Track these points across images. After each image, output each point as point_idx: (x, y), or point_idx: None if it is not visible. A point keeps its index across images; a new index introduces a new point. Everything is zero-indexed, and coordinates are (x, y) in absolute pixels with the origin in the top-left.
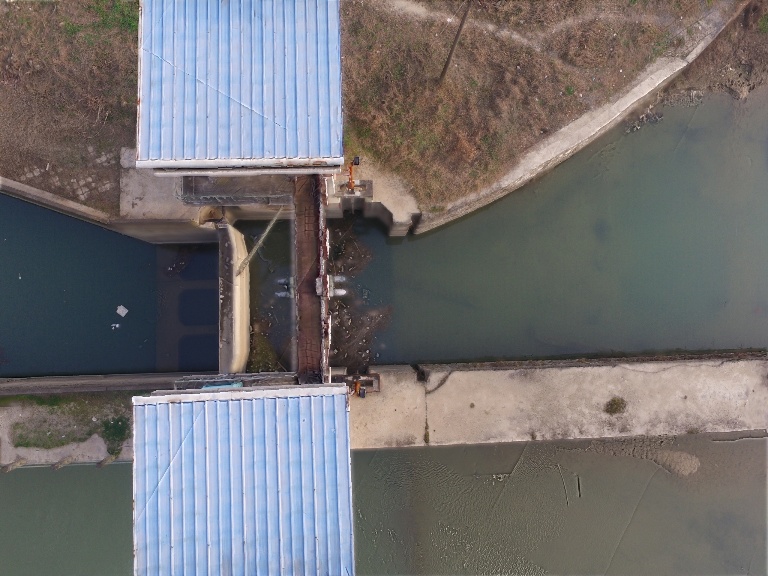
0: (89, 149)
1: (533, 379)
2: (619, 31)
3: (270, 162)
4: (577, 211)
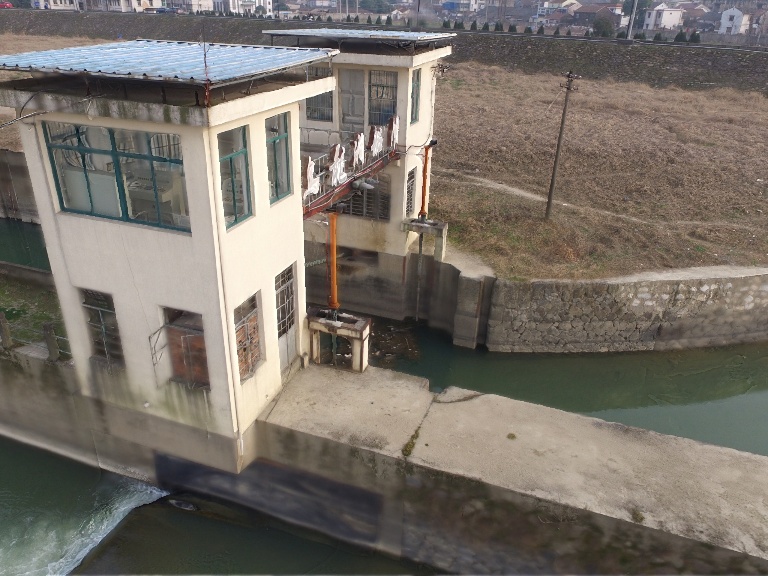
0: None
1: (641, 439)
2: (759, 235)
3: (360, 34)
4: (745, 399)
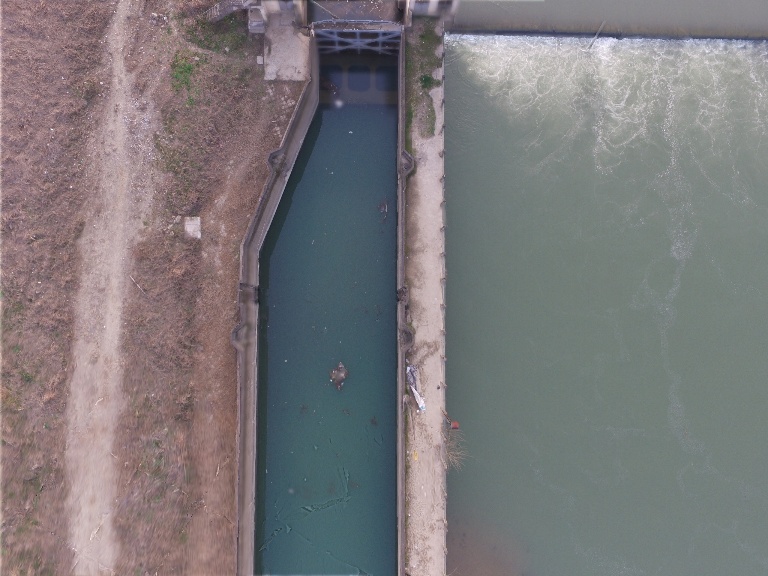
0: (264, 99)
1: None
2: None
3: None
4: None
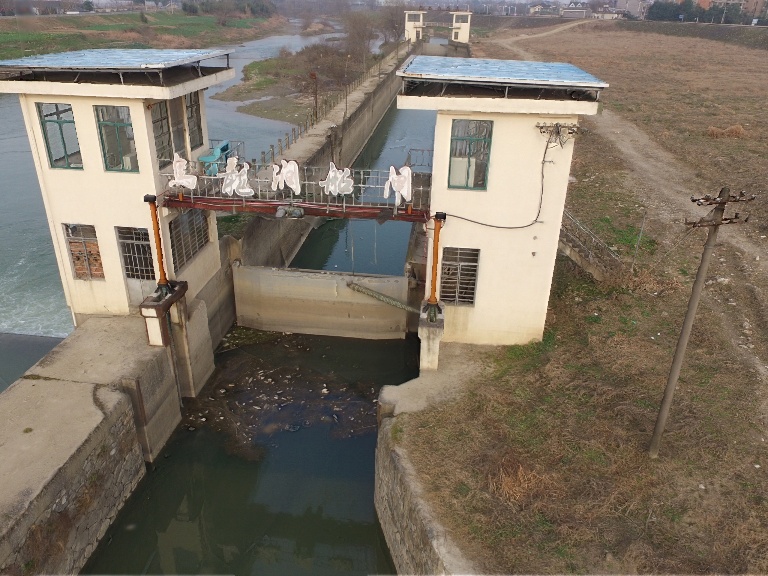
0: None
1: None
2: None
3: None
4: None
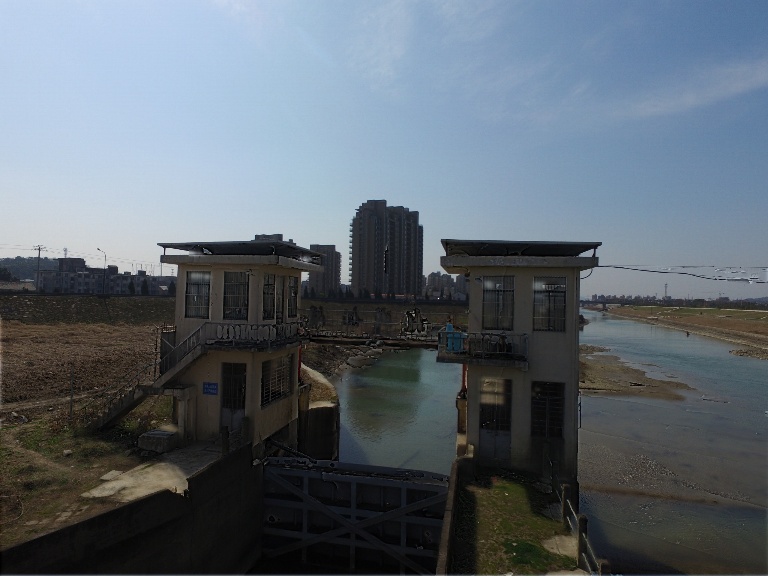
0: (30, 524)
1: None
2: None
3: None
4: None
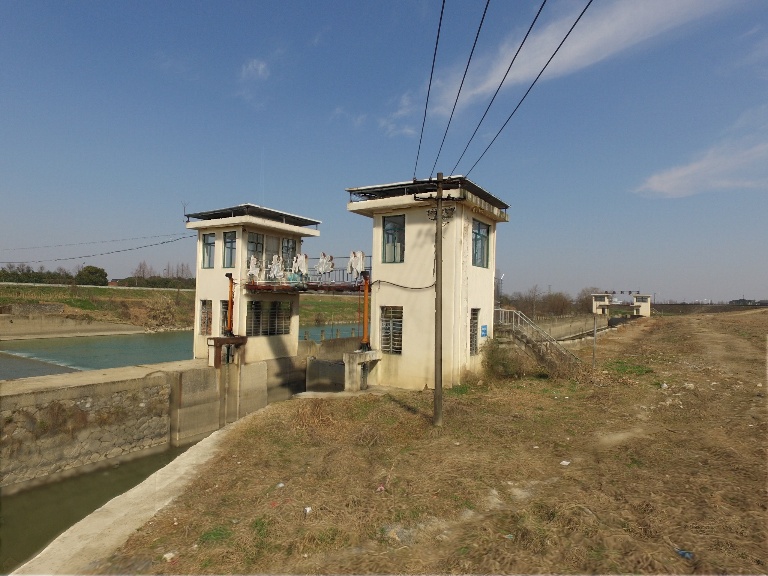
0: None
1: None
2: None
3: None
4: None
